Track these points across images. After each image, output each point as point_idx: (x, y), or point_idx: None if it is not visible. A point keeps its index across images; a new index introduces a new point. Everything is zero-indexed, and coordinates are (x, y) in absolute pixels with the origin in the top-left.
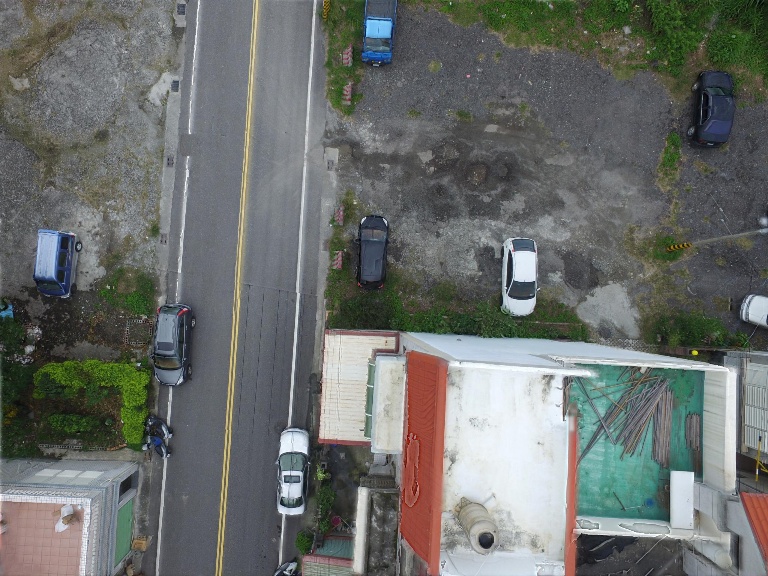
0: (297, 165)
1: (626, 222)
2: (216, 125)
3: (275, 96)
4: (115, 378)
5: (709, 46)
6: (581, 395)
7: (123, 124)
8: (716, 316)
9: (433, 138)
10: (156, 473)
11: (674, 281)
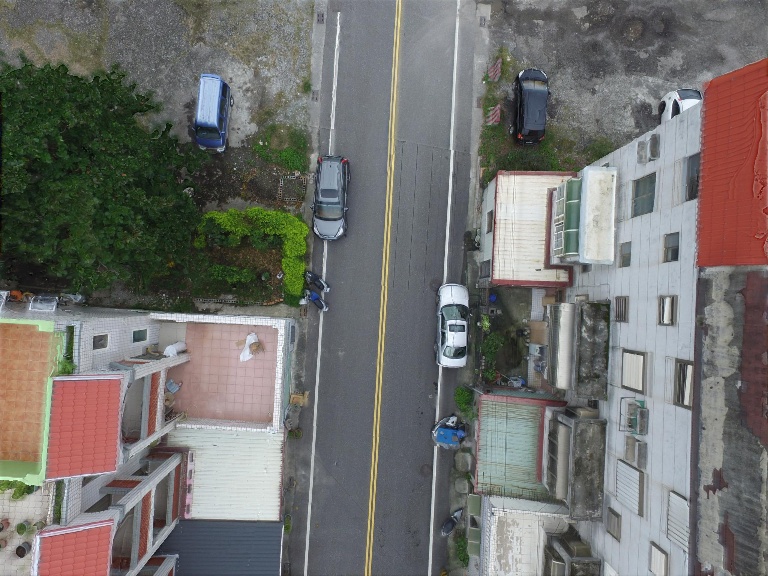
0: (449, 21)
1: None
2: None
3: None
4: (278, 226)
5: None
6: None
7: None
8: None
9: None
10: (312, 329)
11: None
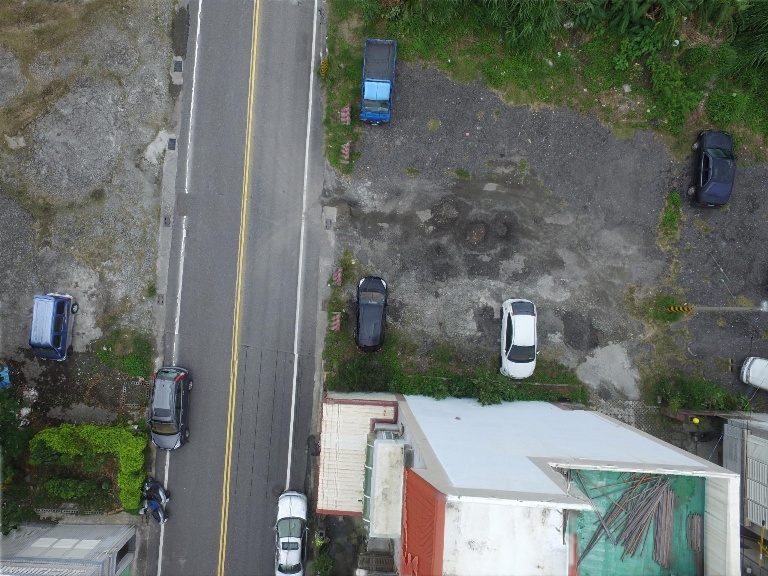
0: (295, 224)
1: (626, 282)
2: (213, 184)
3: (273, 154)
4: (112, 445)
5: (709, 105)
6: (581, 494)
7: (119, 183)
8: (716, 377)
9: (432, 197)
10: (153, 537)
11: (674, 342)
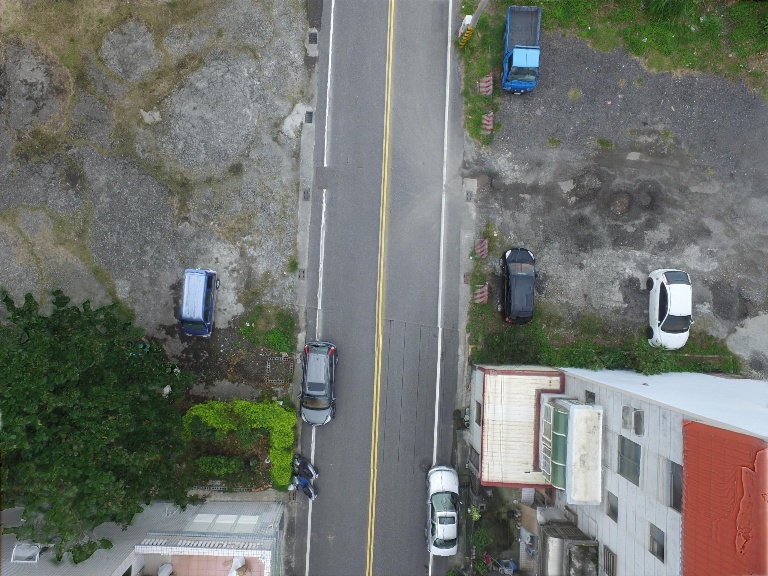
0: (435, 197)
1: None
2: (352, 157)
3: (412, 126)
4: (266, 420)
5: None
6: None
7: (257, 157)
8: None
9: (574, 167)
10: (301, 513)
11: None
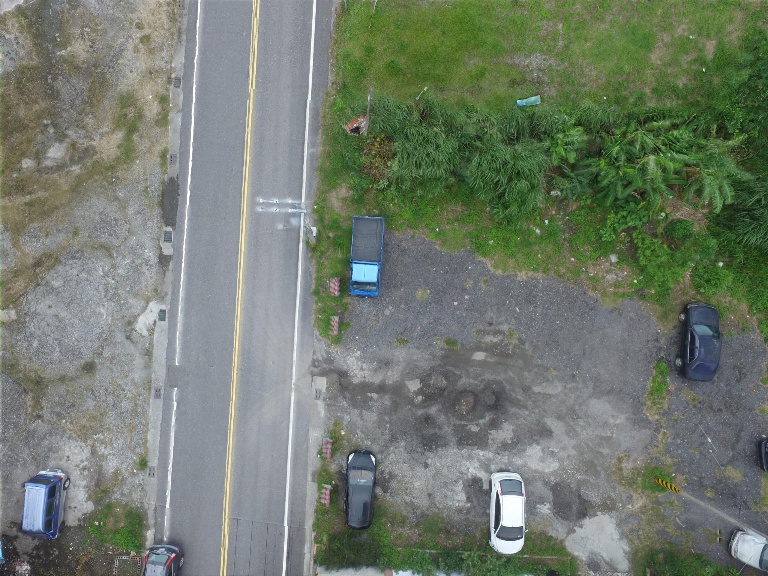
0: (285, 395)
1: (614, 451)
2: (203, 355)
3: (262, 325)
4: None
5: (696, 275)
6: None
7: (110, 355)
8: (705, 548)
9: (421, 366)
10: None
11: (663, 513)
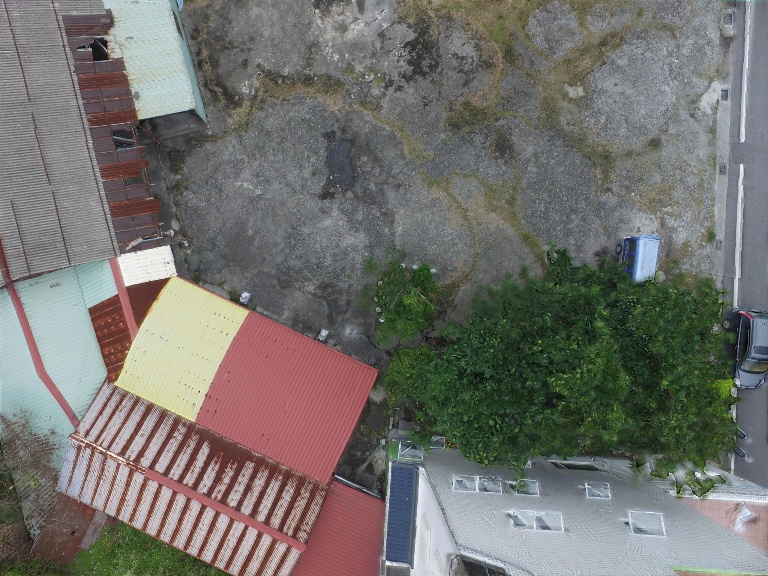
0: None
1: None
2: (767, 134)
3: None
4: None
5: None
6: None
7: (675, 132)
8: None
9: None
10: None
11: None
